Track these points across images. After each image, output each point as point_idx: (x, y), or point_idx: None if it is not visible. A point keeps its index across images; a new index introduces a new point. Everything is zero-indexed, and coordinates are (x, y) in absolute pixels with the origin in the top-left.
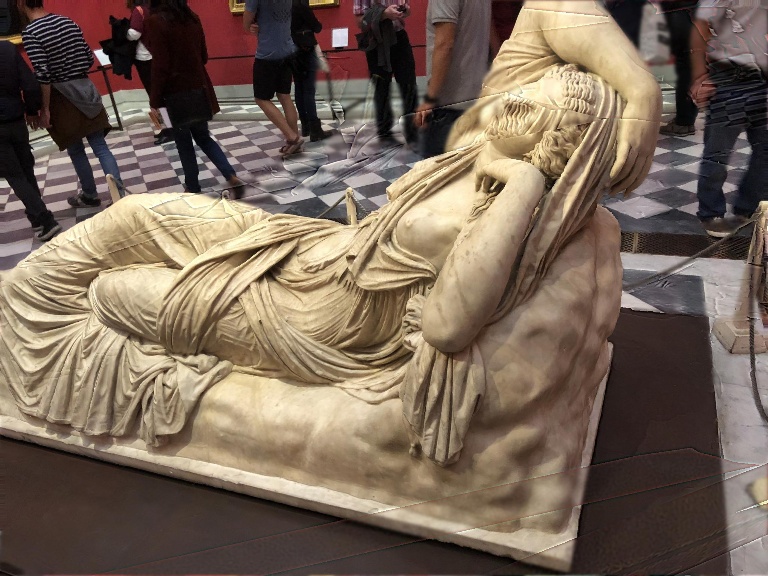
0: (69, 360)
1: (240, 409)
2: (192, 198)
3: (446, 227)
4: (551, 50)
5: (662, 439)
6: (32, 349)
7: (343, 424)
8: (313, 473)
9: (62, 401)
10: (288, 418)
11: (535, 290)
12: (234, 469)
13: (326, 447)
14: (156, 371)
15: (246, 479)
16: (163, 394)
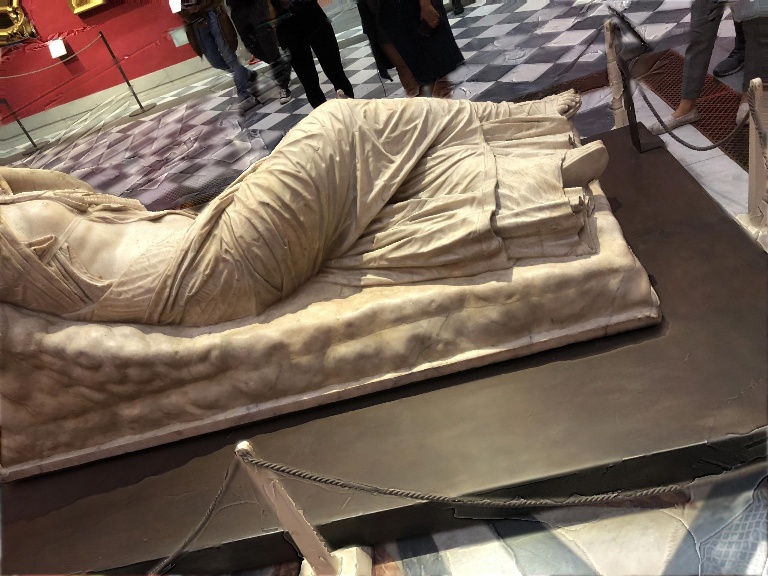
0: None
1: None
2: (82, 26)
3: None
4: None
5: None
6: None
7: None
8: None
9: None
10: None
11: None
12: None
13: None
14: None
15: None
16: None
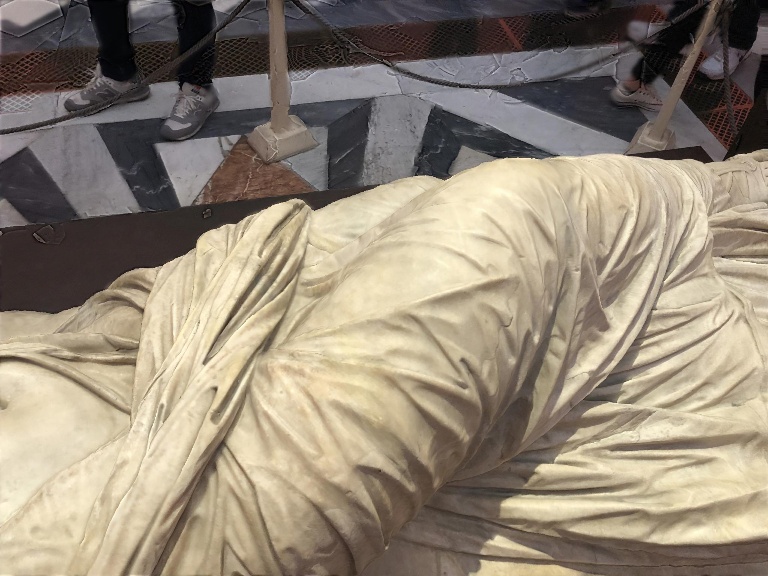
0: None
1: None
2: None
3: None
4: None
5: None
6: None
7: None
8: None
9: None
10: None
11: None
12: None
13: None
14: None
15: None
16: None
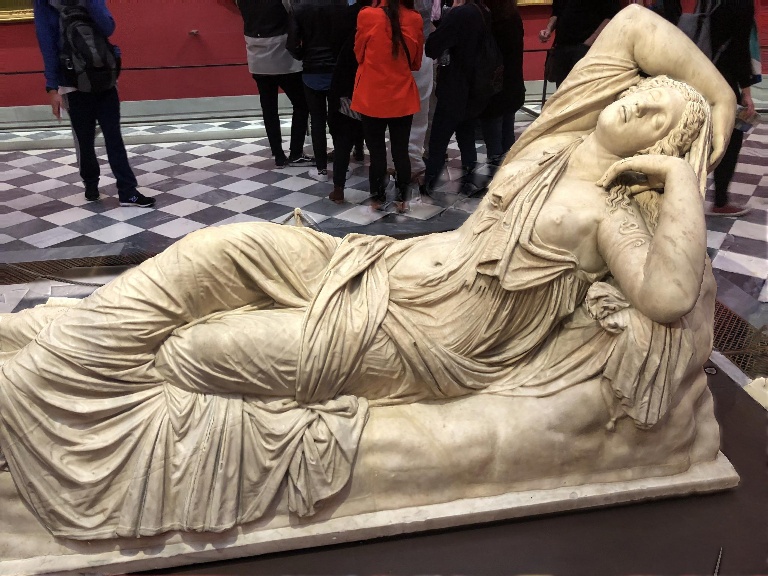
0: (161, 448)
1: (410, 441)
2: None
3: (587, 220)
4: None
5: None
6: (89, 451)
7: (531, 422)
8: (501, 481)
9: (159, 503)
10: (468, 434)
11: None
12: (409, 508)
13: (520, 449)
14: (303, 427)
15: (431, 513)
16: (317, 451)
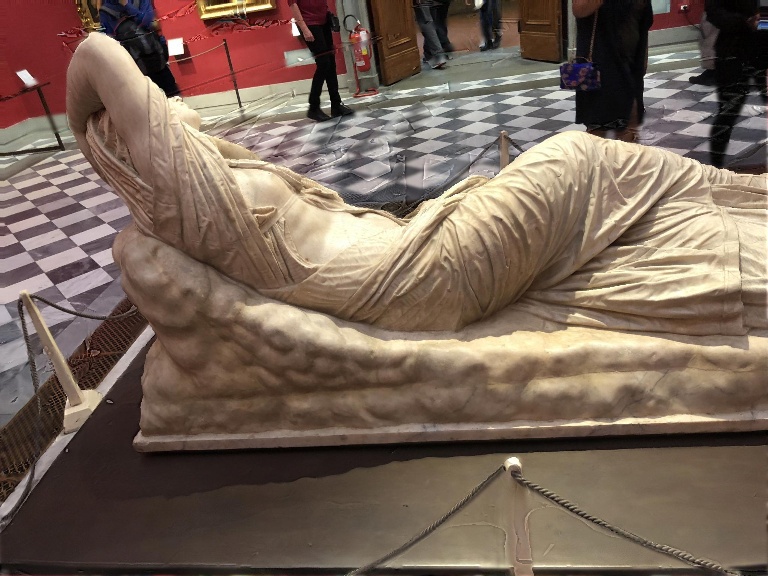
0: None
1: None
2: None
3: None
4: (195, 1)
5: None
6: None
7: None
8: None
9: None
10: None
11: None
12: None
13: None
14: None
15: None
16: None
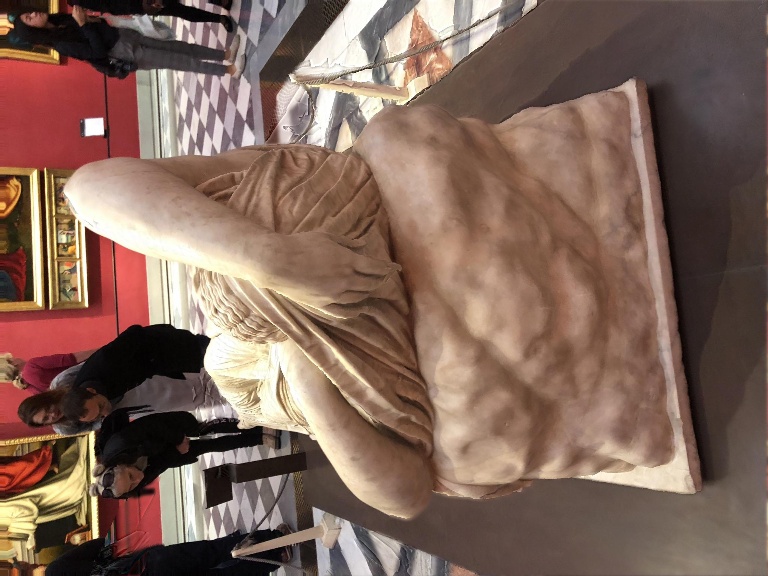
0: None
1: None
2: None
3: None
4: None
5: (752, 221)
6: None
7: None
8: None
9: None
10: None
11: (431, 406)
12: None
13: None
14: None
15: None
16: None
